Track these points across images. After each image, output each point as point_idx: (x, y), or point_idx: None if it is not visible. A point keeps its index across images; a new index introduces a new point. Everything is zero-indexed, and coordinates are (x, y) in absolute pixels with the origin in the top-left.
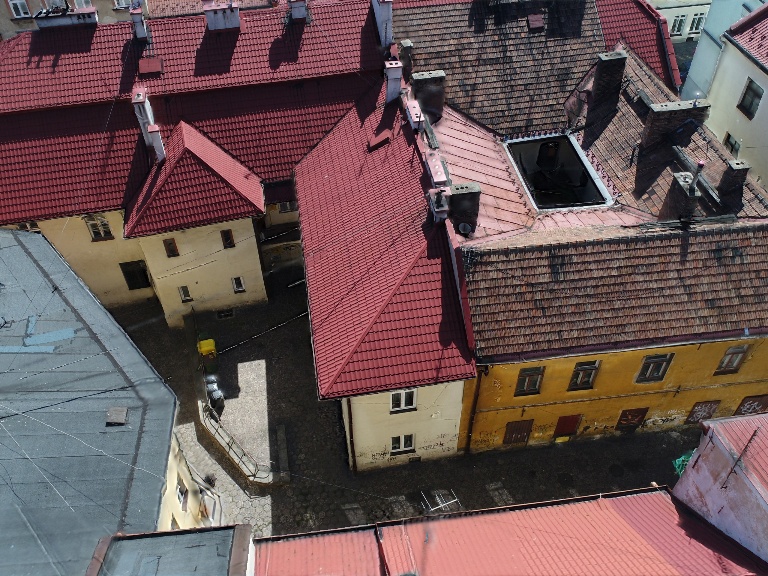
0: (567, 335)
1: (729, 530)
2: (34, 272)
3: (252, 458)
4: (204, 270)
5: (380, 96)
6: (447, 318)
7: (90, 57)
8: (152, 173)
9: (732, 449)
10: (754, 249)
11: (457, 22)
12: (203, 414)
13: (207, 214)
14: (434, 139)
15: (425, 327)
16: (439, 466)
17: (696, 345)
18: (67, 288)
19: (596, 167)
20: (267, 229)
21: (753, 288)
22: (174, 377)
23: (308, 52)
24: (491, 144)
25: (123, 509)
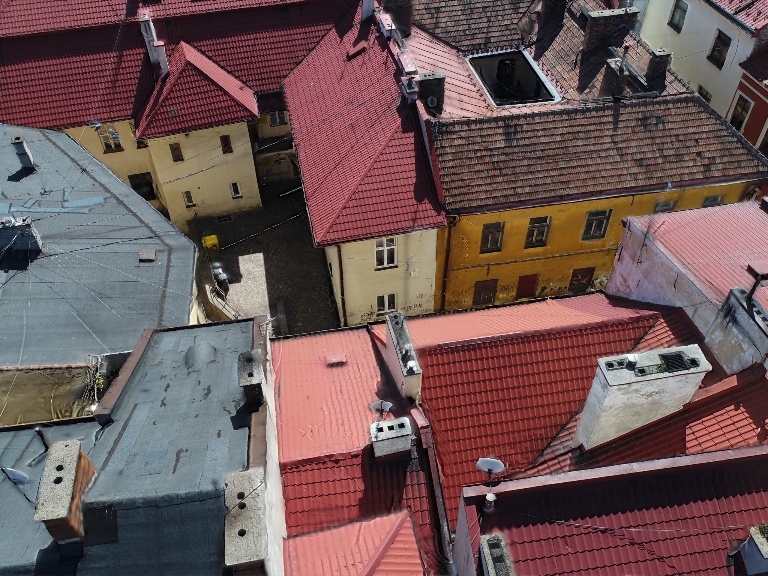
0: (521, 191)
1: (645, 296)
2: (63, 158)
3: None
4: (205, 175)
5: (356, 16)
6: (420, 179)
7: None
8: (157, 86)
9: (644, 229)
10: (674, 117)
11: None
12: (211, 295)
13: (208, 118)
14: (404, 47)
15: (402, 187)
16: None
17: (629, 201)
18: (93, 170)
19: (546, 73)
20: (260, 139)
21: (674, 149)
22: None
23: None
24: (455, 57)
25: (160, 316)
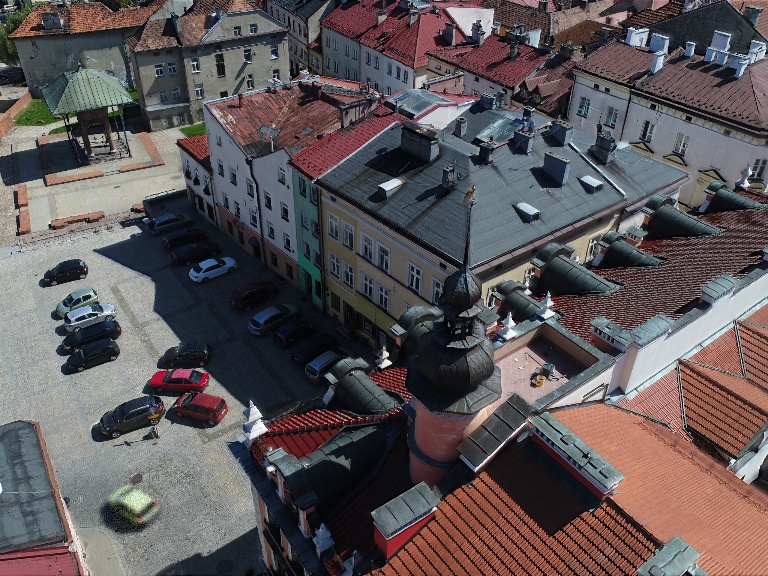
0: None
1: None
2: None
3: None
4: None
5: None
6: None
7: None
8: None
9: None
10: None
11: None
12: None
13: None
14: None
15: None
16: None
17: None
18: None
19: None
20: None
21: None
22: None
23: None
24: (550, 7)
25: None
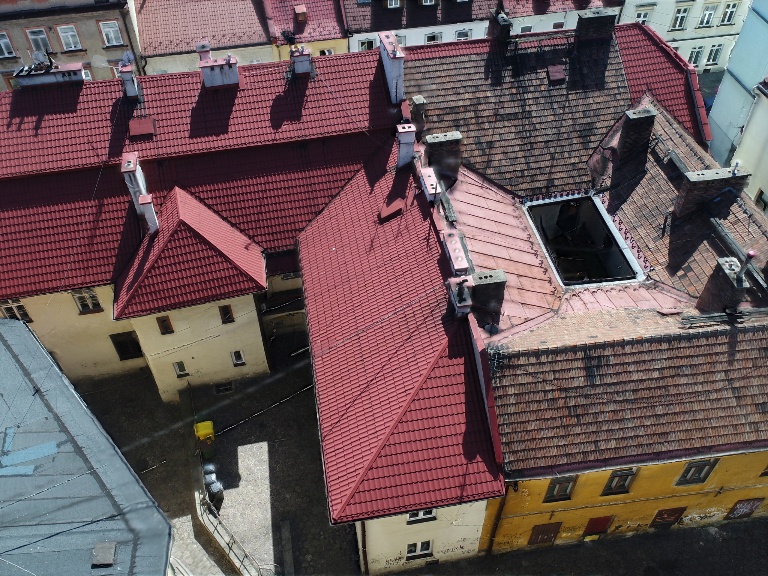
0: (604, 445)
1: None
2: (13, 370)
3: (254, 560)
4: (201, 345)
5: (391, 158)
6: (471, 427)
7: (76, 118)
8: (144, 245)
9: None
10: None
11: (472, 74)
12: (200, 508)
13: (204, 291)
14: (451, 210)
15: (447, 438)
16: (458, 569)
17: None
18: (50, 389)
19: (624, 235)
20: (269, 299)
21: None
22: (169, 461)
23: (312, 110)
24: (510, 208)
25: None
